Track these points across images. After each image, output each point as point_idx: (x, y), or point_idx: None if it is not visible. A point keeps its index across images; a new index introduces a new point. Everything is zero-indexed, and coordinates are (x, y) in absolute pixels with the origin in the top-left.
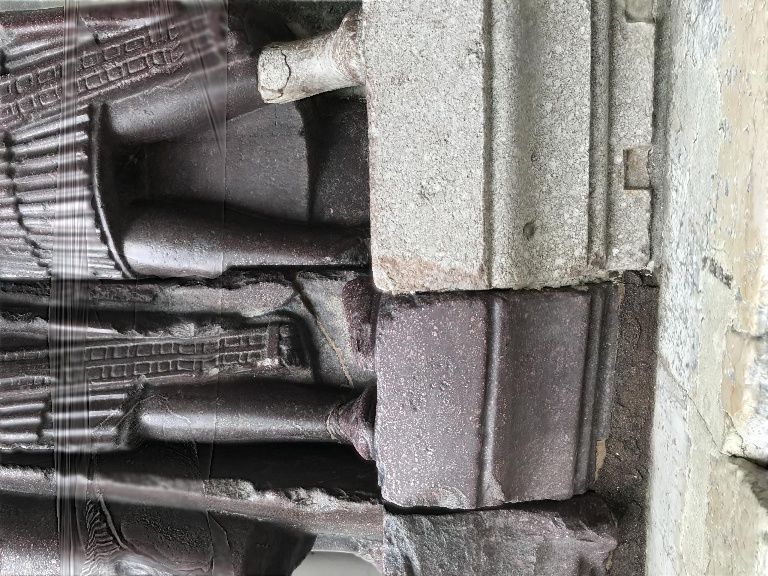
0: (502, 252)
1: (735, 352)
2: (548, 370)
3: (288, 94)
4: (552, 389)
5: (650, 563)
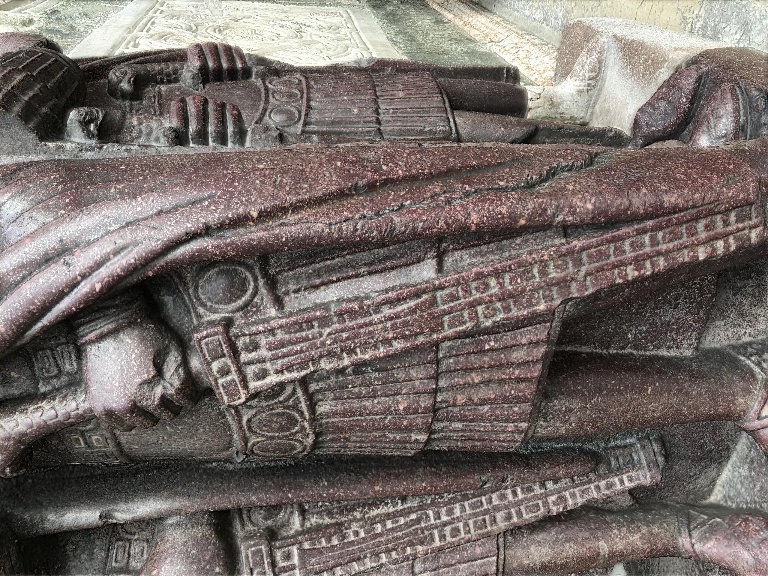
0: None
1: None
2: None
3: (543, 99)
4: None
5: None
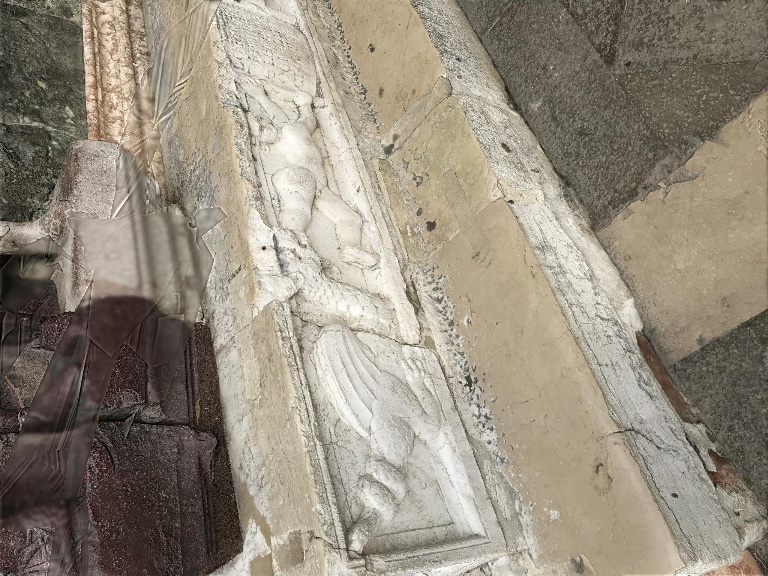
0: None
1: (248, 281)
2: None
3: (4, 241)
4: None
5: (234, 460)
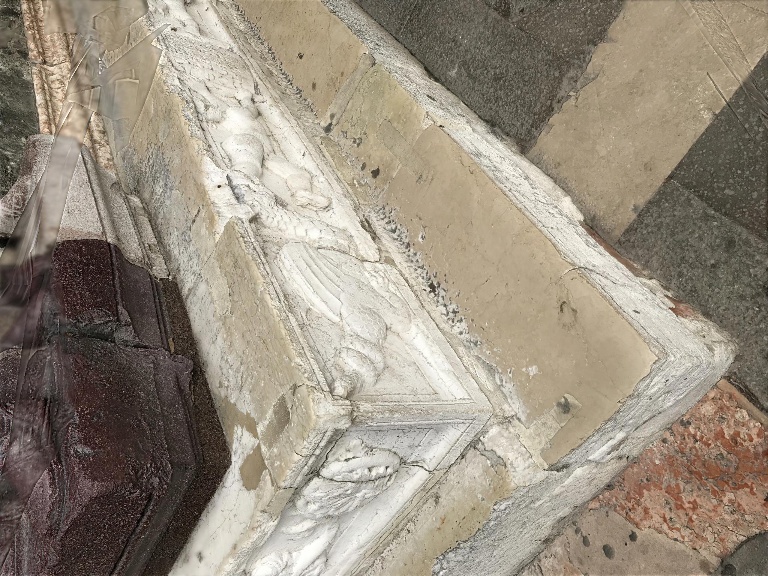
0: (110, 233)
1: None
2: (137, 290)
3: None
4: (141, 298)
5: (213, 383)
